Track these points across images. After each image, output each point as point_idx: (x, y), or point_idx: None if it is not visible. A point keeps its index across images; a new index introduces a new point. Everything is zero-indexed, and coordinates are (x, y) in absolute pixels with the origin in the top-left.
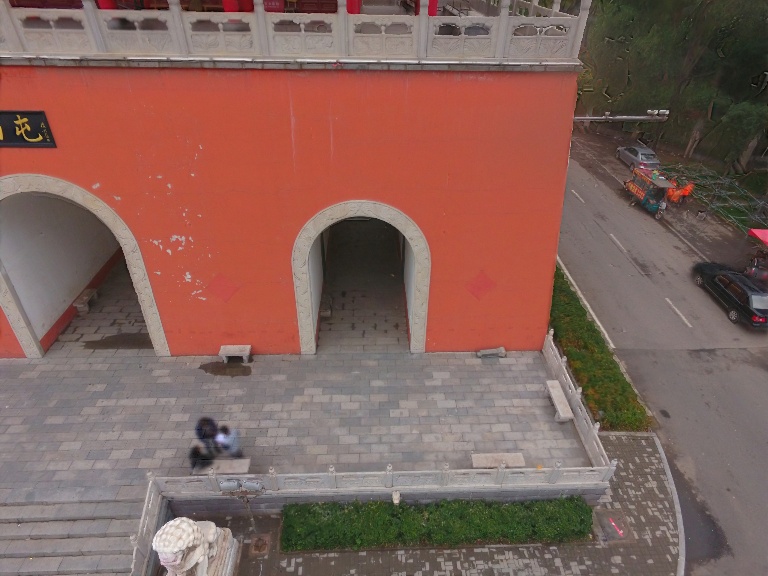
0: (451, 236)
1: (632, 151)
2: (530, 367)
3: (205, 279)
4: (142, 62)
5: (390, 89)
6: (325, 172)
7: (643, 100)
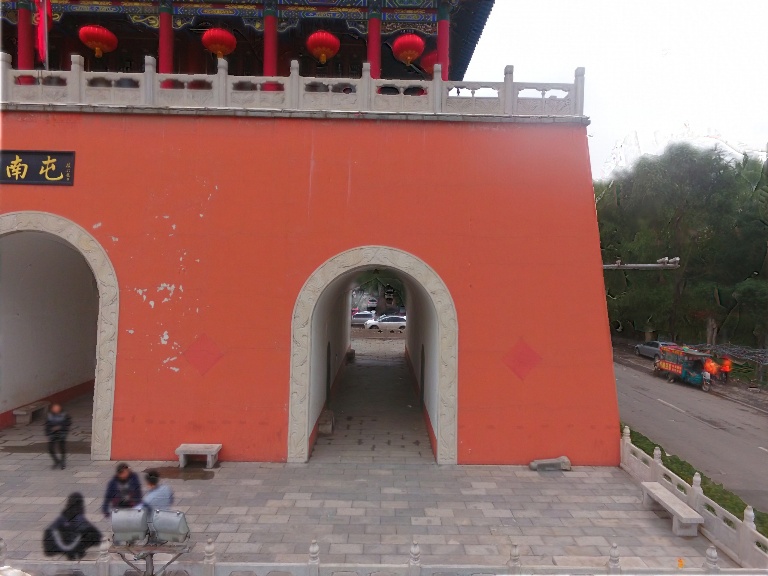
0: (479, 291)
1: (651, 344)
2: (610, 480)
3: (185, 342)
4: (182, 111)
5: (408, 137)
6: (340, 216)
7: (647, 298)
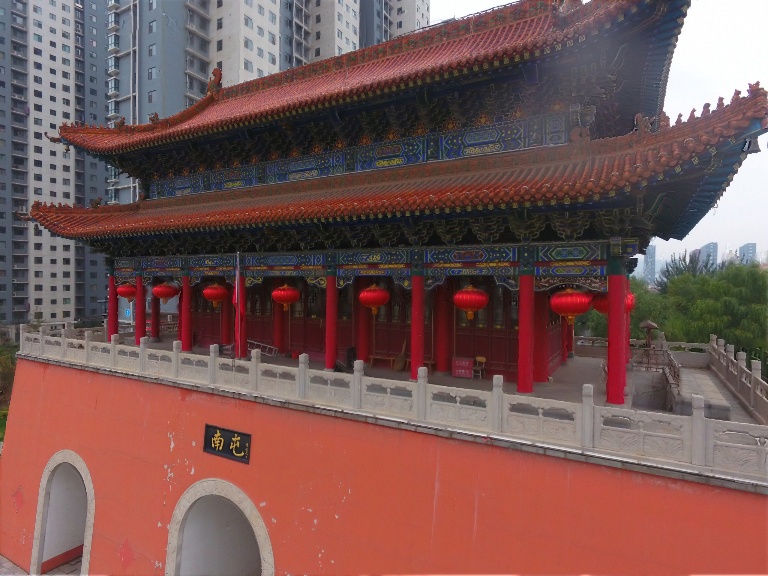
0: None
1: None
2: None
3: None
4: (324, 410)
5: (547, 475)
6: (465, 553)
7: None
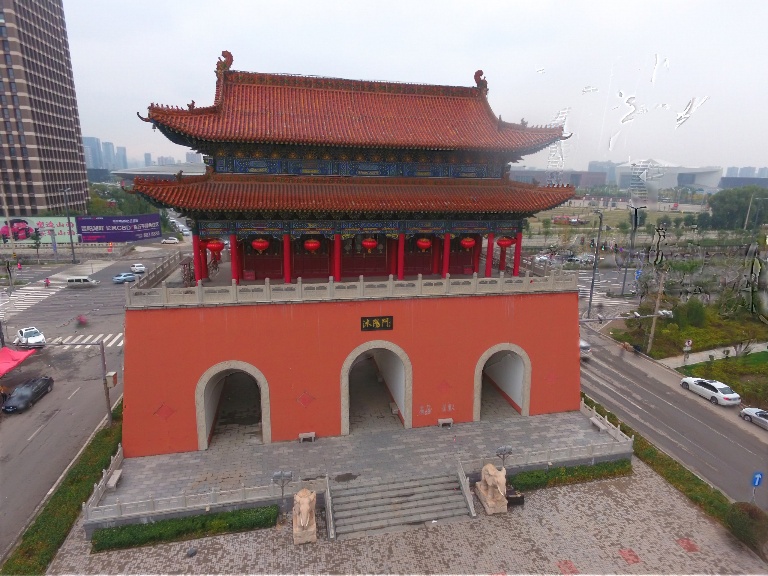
0: None
1: None
2: None
3: None
4: None
5: None
6: None
7: None
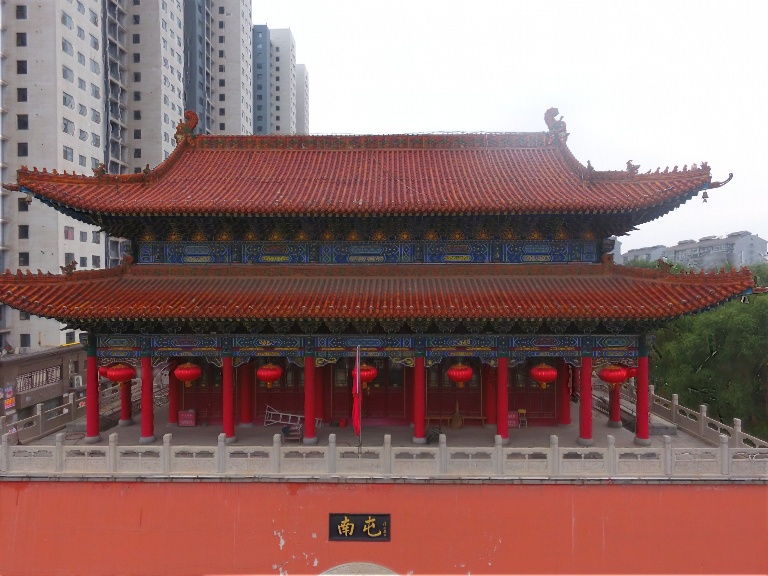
0: None
1: None
2: None
3: None
4: (471, 480)
5: (647, 497)
6: (597, 562)
7: None
